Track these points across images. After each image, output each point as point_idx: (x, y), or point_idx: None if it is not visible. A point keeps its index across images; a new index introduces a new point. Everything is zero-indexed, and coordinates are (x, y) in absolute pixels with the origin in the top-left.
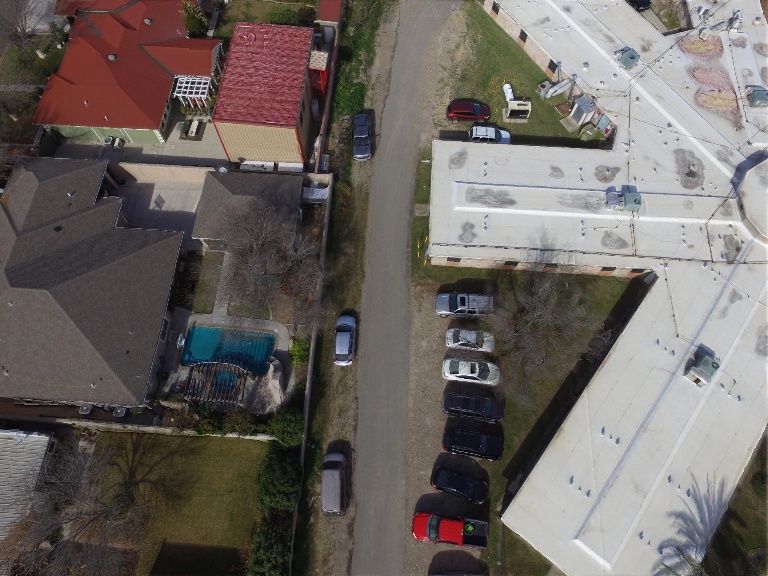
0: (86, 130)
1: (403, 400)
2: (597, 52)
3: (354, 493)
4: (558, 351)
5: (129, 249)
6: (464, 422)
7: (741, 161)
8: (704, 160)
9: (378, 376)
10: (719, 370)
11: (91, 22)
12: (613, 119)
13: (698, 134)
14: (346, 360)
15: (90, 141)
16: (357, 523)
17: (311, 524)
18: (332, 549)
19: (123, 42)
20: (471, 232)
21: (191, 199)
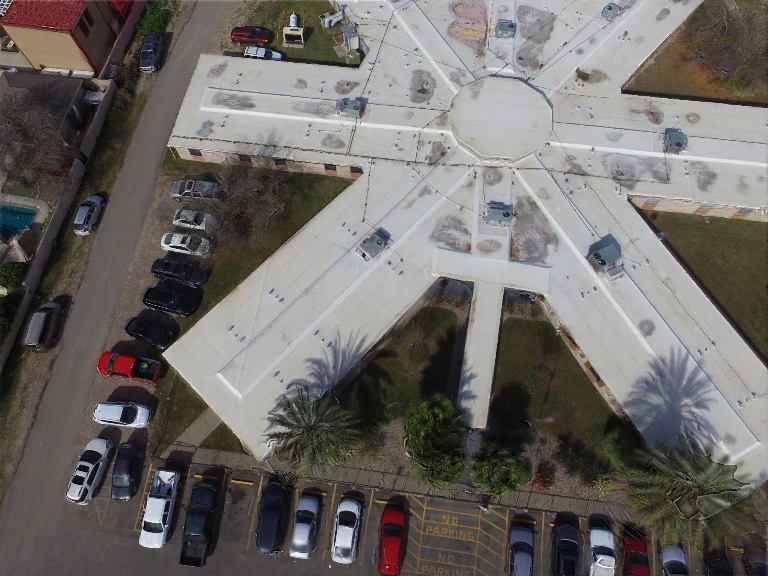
0: None
1: (125, 265)
2: None
3: (63, 336)
4: (253, 226)
5: None
6: (172, 286)
7: (470, 82)
8: (438, 80)
9: (110, 246)
10: (391, 250)
11: None
12: (367, 43)
13: (439, 58)
14: (82, 229)
15: None
16: (59, 360)
17: (22, 359)
18: (33, 379)
19: None
20: (209, 128)
21: None
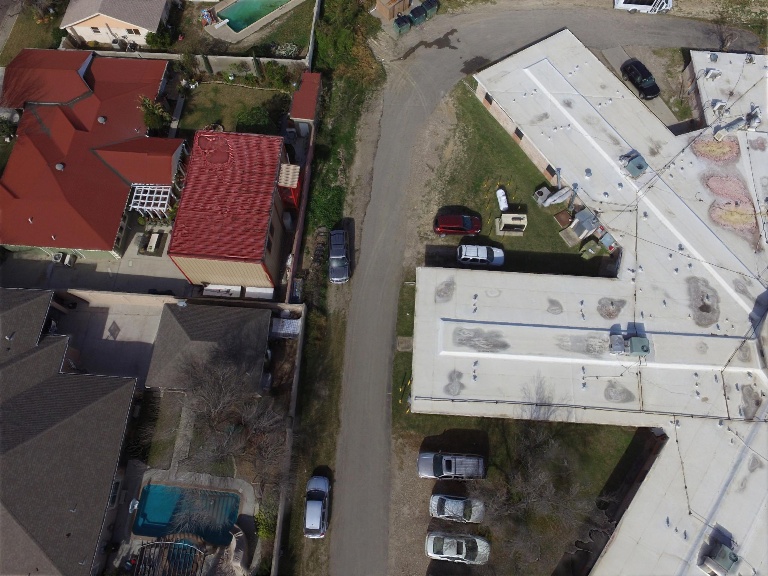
0: (33, 247)
1: None
2: (601, 156)
3: None
4: (555, 534)
5: (73, 406)
6: None
7: (761, 292)
8: (719, 290)
9: (353, 551)
10: None
11: (40, 117)
12: (618, 239)
13: (713, 259)
14: (317, 535)
15: (38, 255)
16: None
17: None
18: None
19: (73, 148)
20: (458, 382)
21: (149, 327)
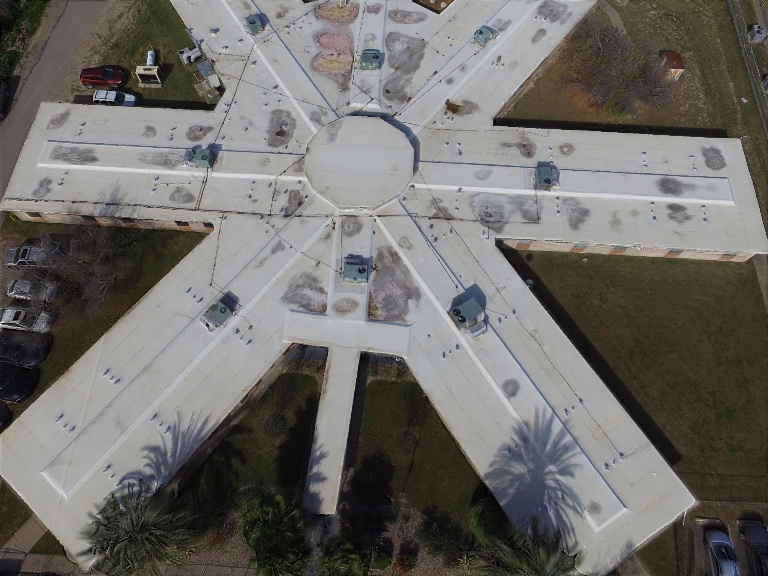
0: None
1: None
2: (232, 19)
3: None
4: None
5: None
6: (6, 368)
7: (332, 121)
8: (298, 120)
9: None
10: (239, 316)
11: None
12: (224, 82)
13: (299, 95)
14: None
15: None
16: None
17: None
18: None
19: None
20: (46, 188)
21: None
